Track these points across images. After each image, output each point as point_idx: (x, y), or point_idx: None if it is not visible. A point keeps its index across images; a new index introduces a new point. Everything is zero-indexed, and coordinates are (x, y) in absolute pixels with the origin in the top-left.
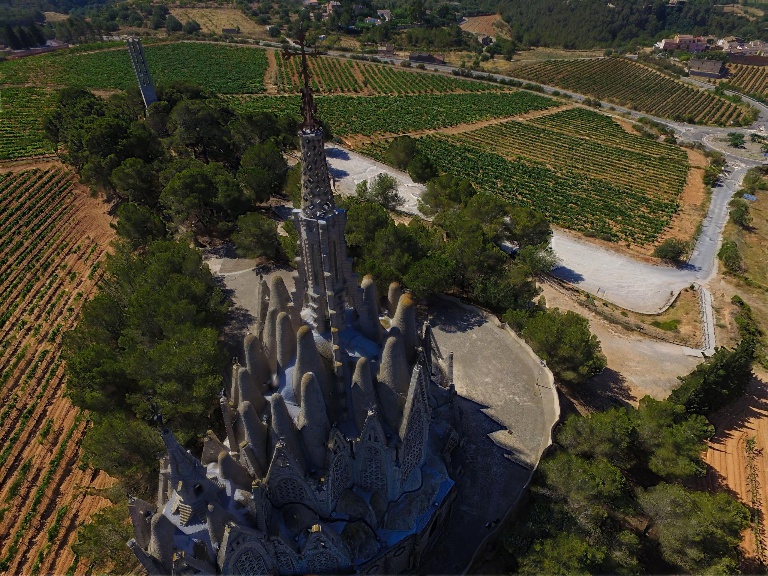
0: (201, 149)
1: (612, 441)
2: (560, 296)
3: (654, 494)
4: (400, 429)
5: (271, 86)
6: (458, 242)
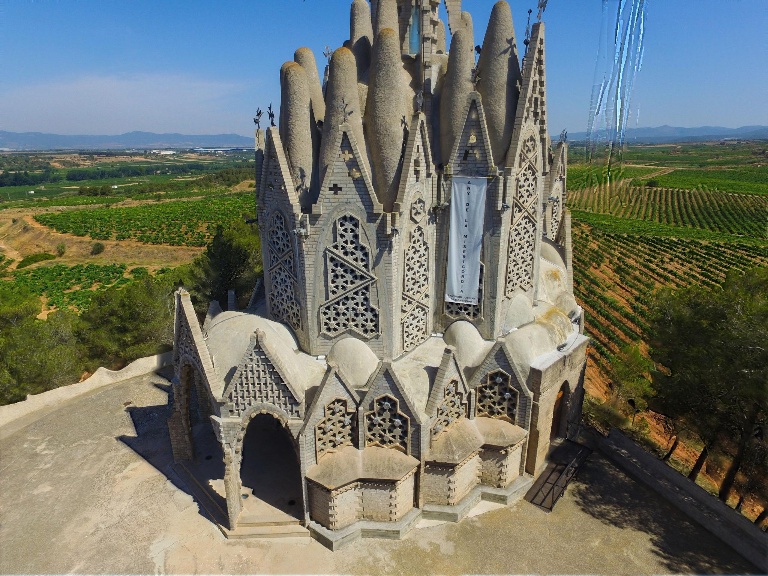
0: None
1: None
2: None
3: None
4: None
5: None
6: None
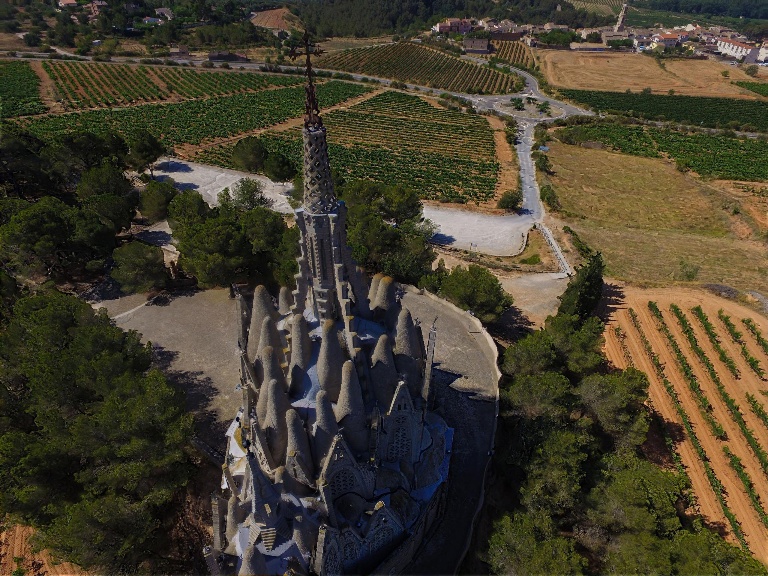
0: (6, 187)
1: (546, 356)
2: (446, 257)
3: (582, 387)
4: (423, 391)
5: (53, 103)
6: (358, 227)
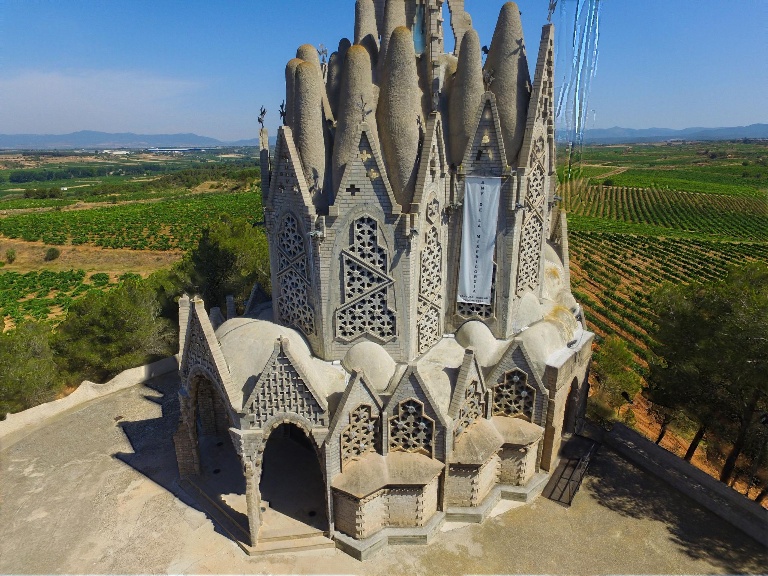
0: None
1: None
2: None
3: None
4: None
5: None
6: None
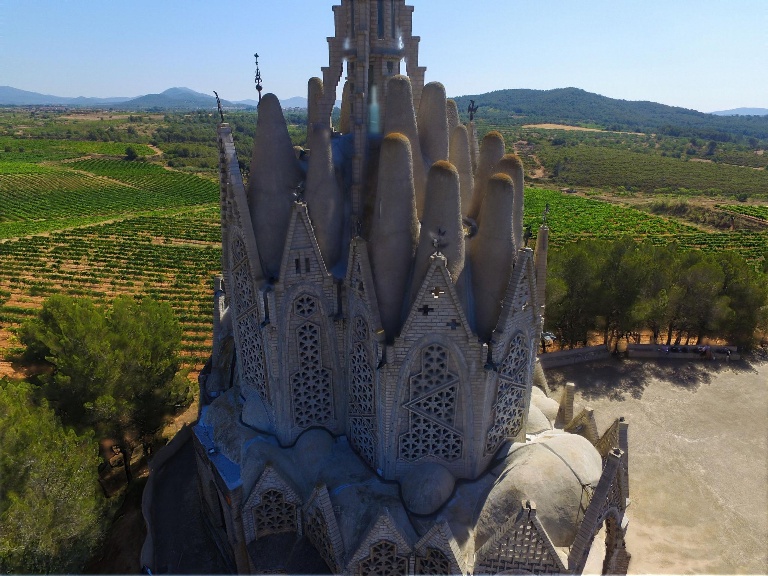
0: None
1: None
2: None
3: None
4: None
5: None
6: None
